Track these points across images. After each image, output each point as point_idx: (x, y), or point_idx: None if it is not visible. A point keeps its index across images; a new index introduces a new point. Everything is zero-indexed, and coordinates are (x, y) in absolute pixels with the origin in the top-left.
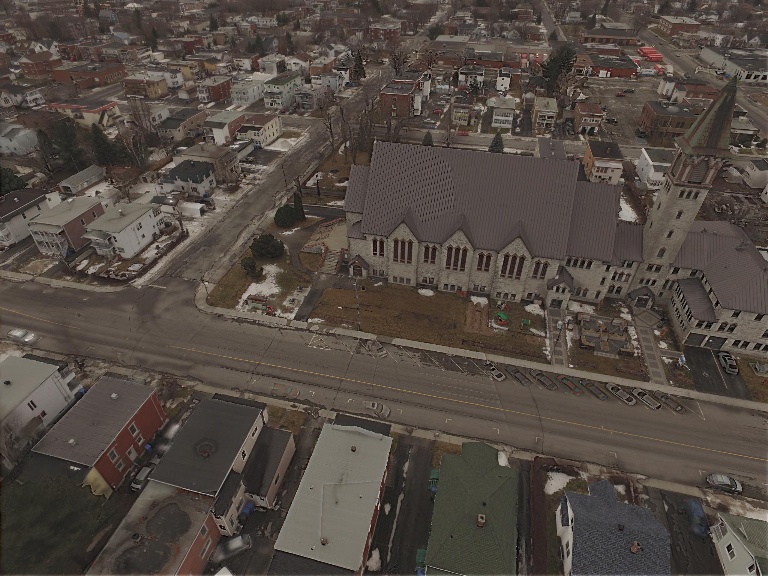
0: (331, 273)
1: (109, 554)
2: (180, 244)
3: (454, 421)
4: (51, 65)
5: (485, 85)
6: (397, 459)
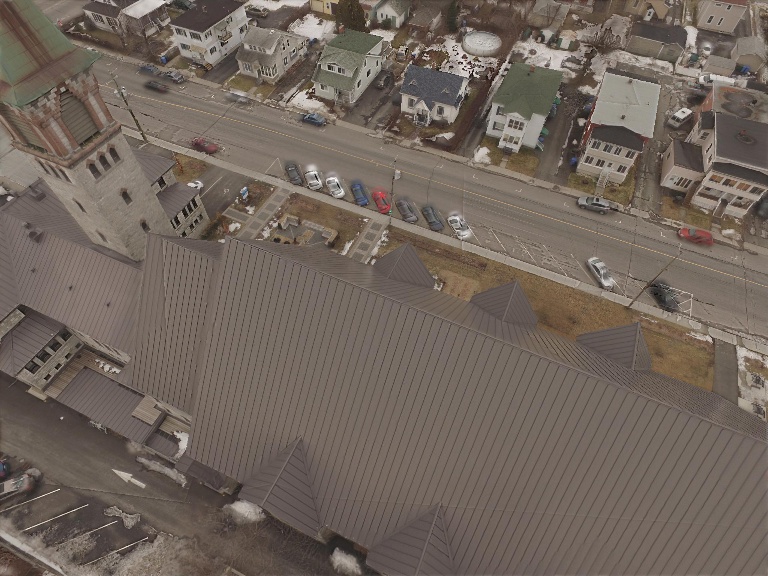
0: None
1: (764, 102)
2: None
3: (514, 189)
4: None
5: None
6: (569, 168)
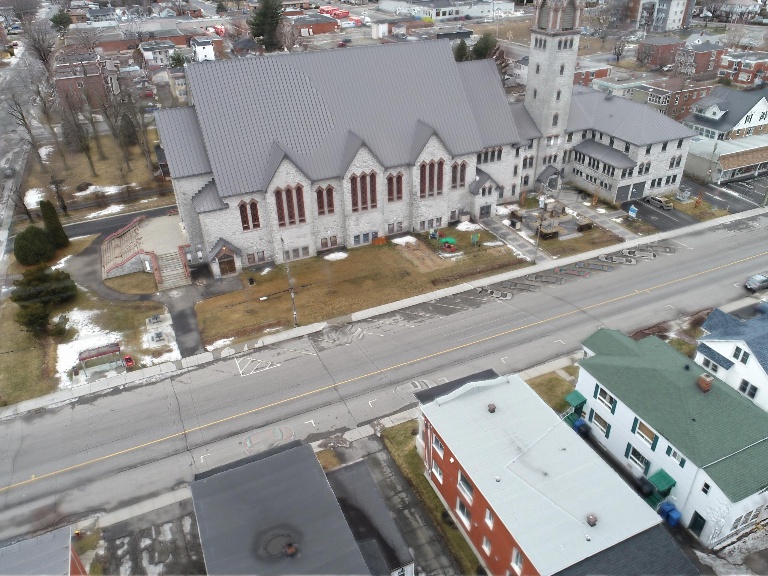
0: (183, 285)
1: None
2: None
3: (511, 357)
4: None
5: None
6: None
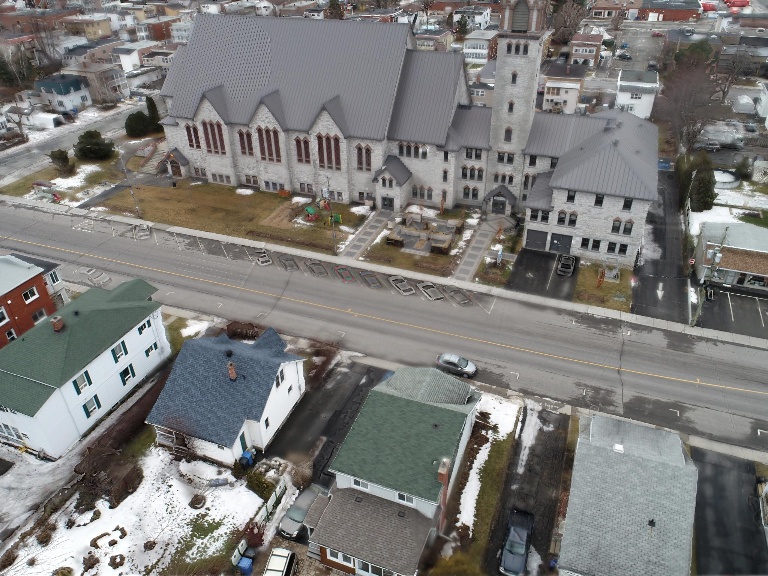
0: (151, 173)
1: None
2: (12, 147)
3: (176, 294)
4: (2, 11)
5: (489, 28)
6: None
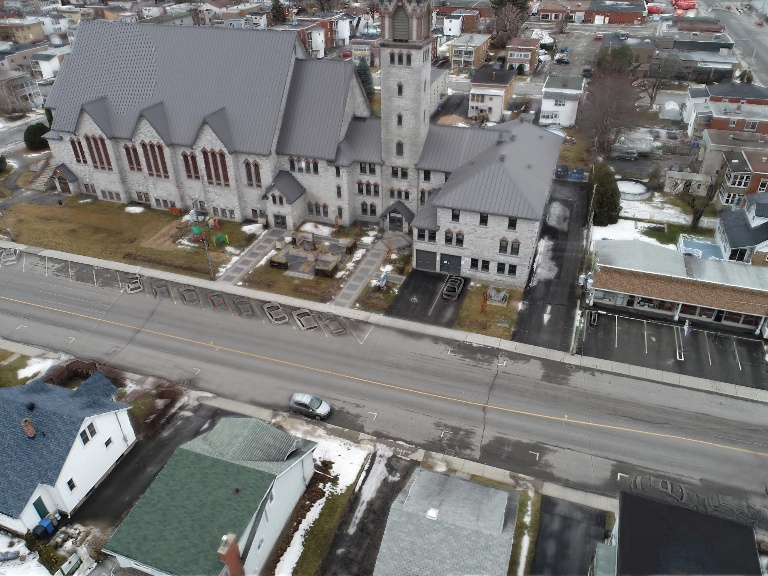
0: (39, 190)
1: None
2: None
3: (27, 328)
4: None
5: None
6: None
